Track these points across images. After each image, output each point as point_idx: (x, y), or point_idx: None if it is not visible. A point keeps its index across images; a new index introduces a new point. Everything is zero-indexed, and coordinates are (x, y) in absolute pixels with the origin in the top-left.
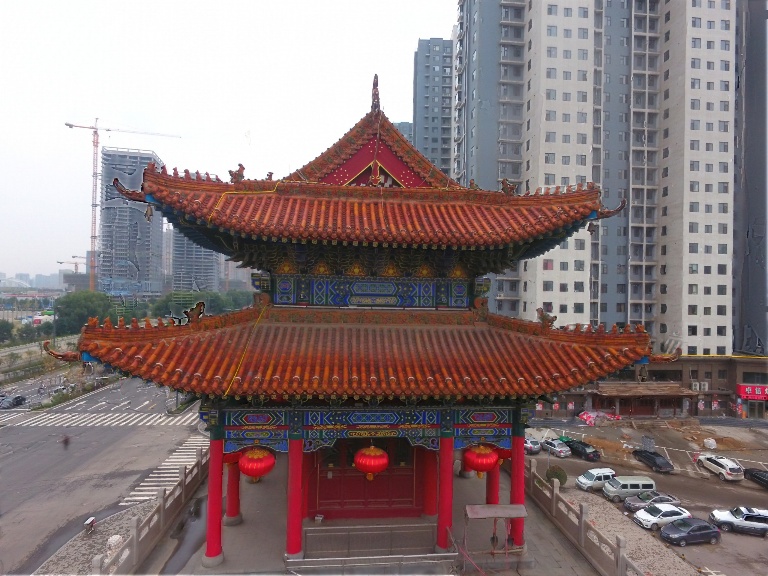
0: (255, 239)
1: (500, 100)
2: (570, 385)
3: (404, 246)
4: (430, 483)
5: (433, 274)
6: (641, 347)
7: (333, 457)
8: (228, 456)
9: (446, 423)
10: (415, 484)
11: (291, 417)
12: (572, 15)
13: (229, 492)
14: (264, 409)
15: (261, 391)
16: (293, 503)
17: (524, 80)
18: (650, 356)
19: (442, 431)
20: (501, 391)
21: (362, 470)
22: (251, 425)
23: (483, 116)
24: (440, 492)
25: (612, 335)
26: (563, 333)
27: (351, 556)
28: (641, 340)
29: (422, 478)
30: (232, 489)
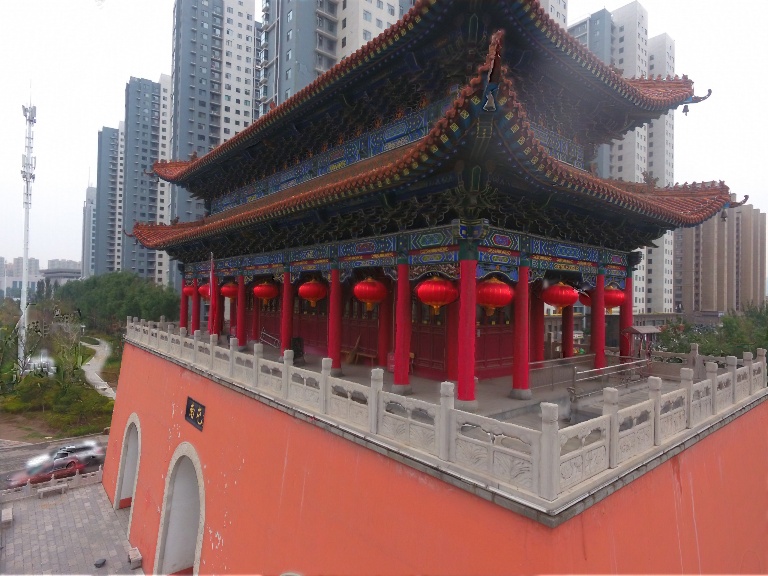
0: (537, 26)
1: (316, 68)
2: (701, 218)
3: (610, 84)
4: (541, 338)
5: (564, 135)
6: (724, 196)
7: (479, 315)
8: (448, 294)
9: (603, 261)
10: (530, 341)
11: (523, 243)
12: (383, 8)
13: (405, 355)
14: (508, 230)
15: (586, 182)
16: (526, 335)
17: (337, 55)
18: (730, 202)
19: (600, 269)
20: (680, 217)
21: (564, 302)
22: (495, 248)
23: (300, 79)
24: (599, 324)
25: (703, 189)
26: (666, 190)
27: (556, 388)
28: (724, 191)
29: (534, 335)
30: (408, 351)
